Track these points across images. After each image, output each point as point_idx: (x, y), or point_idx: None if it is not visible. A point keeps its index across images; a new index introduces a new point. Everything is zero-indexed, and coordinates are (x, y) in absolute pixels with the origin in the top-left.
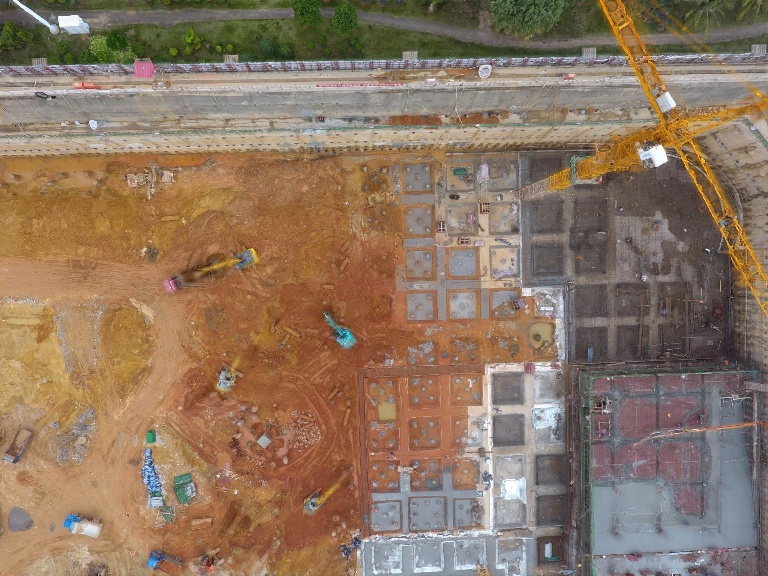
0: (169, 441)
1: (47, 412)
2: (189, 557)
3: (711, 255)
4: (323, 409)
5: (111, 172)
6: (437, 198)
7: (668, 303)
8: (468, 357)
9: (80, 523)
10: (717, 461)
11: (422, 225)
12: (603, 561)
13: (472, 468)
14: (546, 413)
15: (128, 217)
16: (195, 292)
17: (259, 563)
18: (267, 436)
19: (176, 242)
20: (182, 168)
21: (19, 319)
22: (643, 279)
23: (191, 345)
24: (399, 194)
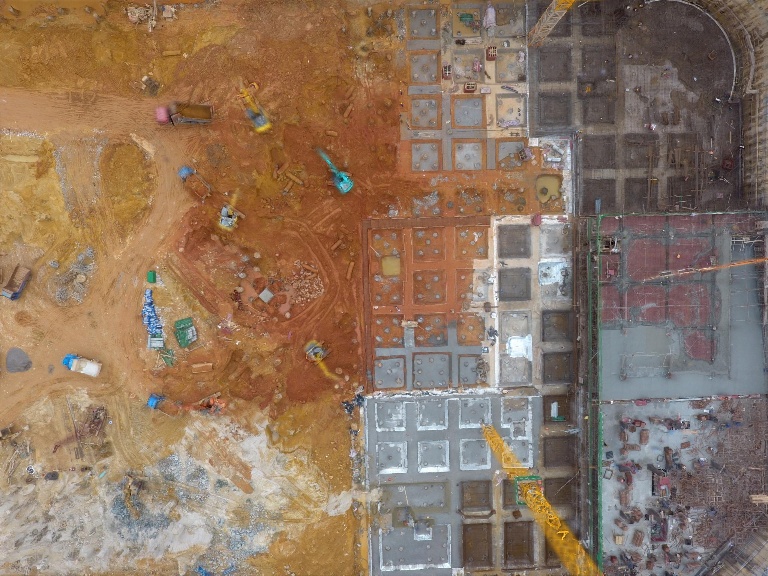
0: (170, 284)
1: (46, 251)
2: (190, 401)
3: (721, 105)
4: (326, 261)
5: (111, 7)
6: (443, 44)
7: (677, 154)
8: (474, 210)
9: (79, 361)
10: (727, 305)
11: (427, 73)
12: (611, 407)
13: (477, 325)
14: (553, 270)
15: (129, 50)
16: (196, 128)
17: (261, 414)
18: (269, 290)
19: (177, 76)
20: (184, 5)
21: (18, 156)
22: (652, 127)
23: (192, 183)
24: (404, 39)
